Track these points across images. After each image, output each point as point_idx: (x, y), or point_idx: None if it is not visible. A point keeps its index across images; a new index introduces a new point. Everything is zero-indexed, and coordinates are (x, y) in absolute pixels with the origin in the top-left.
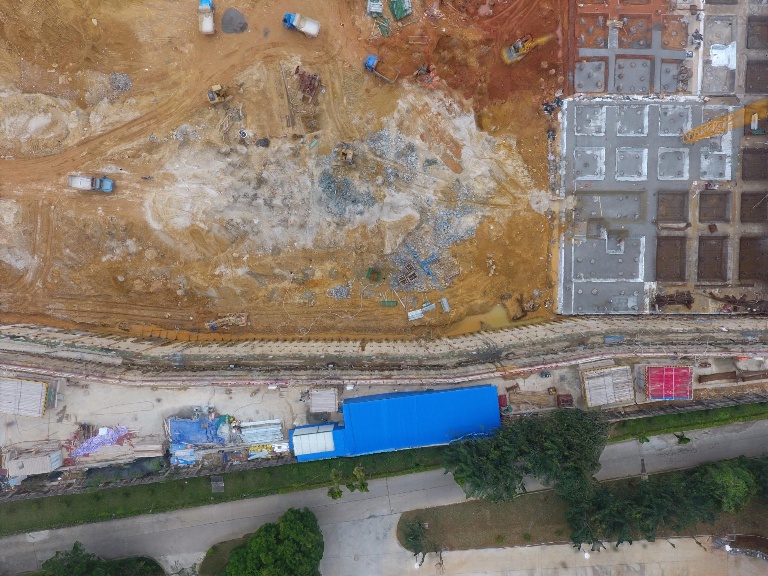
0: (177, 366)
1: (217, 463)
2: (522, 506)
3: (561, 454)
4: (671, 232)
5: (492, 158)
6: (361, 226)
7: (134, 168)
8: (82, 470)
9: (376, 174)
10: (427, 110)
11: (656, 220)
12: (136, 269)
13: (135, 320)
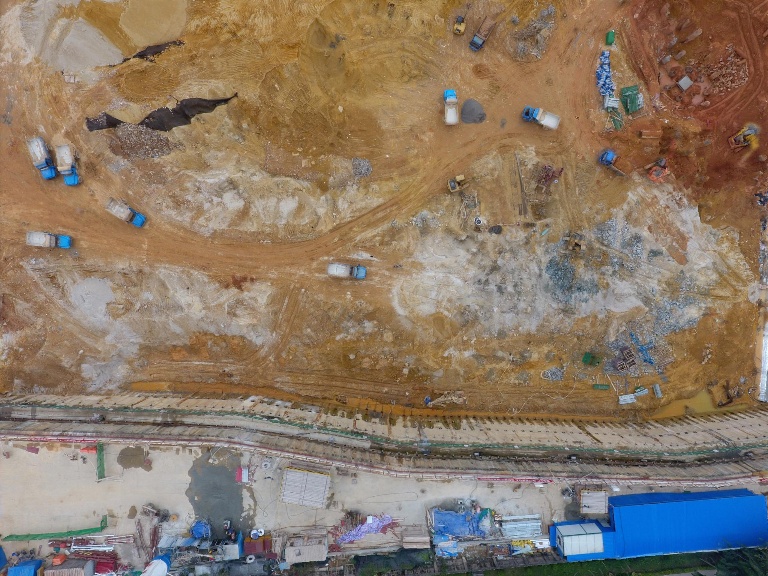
0: (423, 452)
1: (479, 556)
2: None
3: None
4: None
5: (716, 251)
6: (592, 316)
7: (384, 256)
8: (348, 557)
9: (600, 262)
10: (656, 203)
11: None
12: (368, 348)
13: (353, 393)
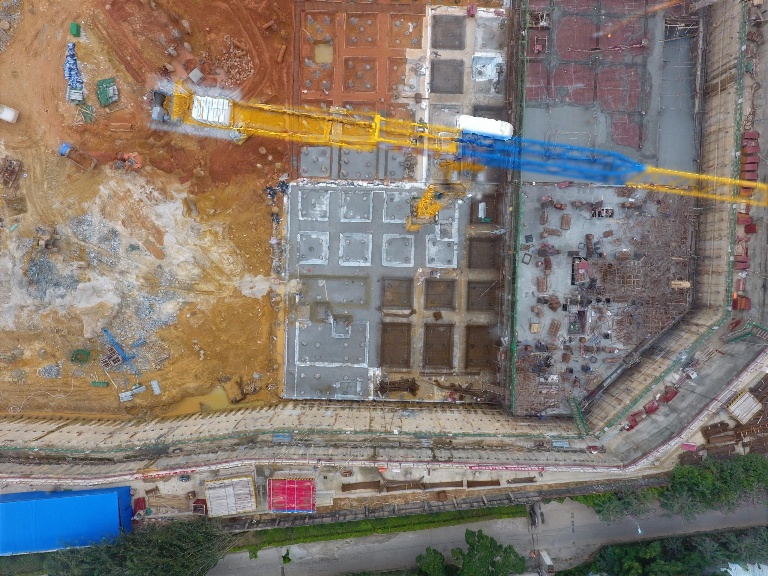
0: None
1: None
2: None
3: None
4: (394, 319)
5: (196, 245)
6: (52, 312)
7: None
8: None
9: (81, 257)
10: (129, 196)
11: (380, 306)
12: None
13: None
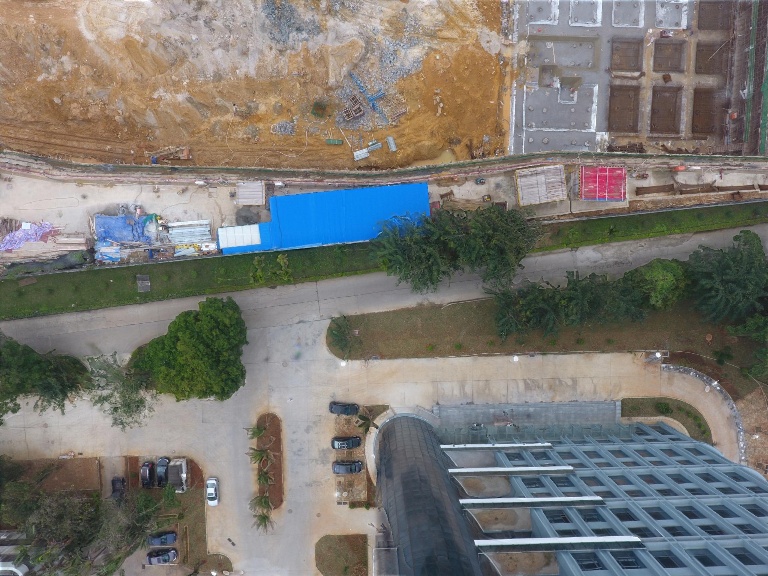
0: None
1: (143, 261)
2: (454, 315)
3: (486, 237)
4: (624, 80)
5: None
6: (303, 49)
7: None
8: None
9: None
10: None
11: (609, 68)
12: (72, 91)
13: (74, 152)
